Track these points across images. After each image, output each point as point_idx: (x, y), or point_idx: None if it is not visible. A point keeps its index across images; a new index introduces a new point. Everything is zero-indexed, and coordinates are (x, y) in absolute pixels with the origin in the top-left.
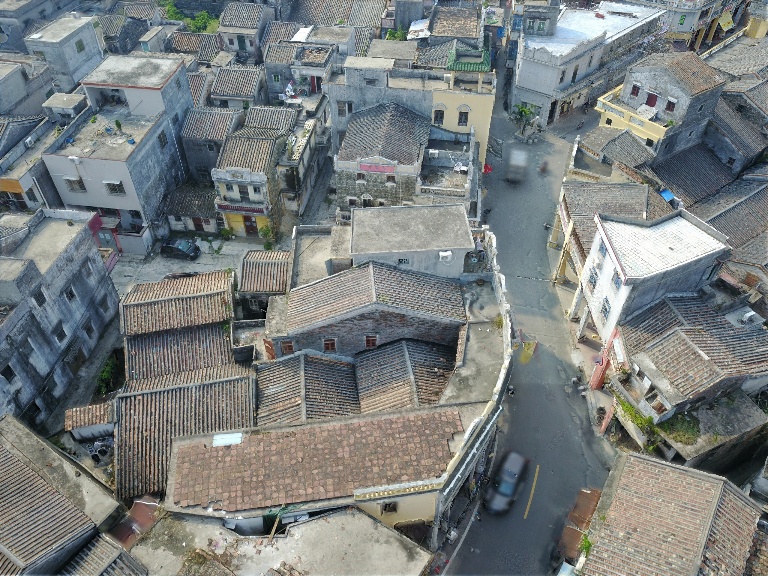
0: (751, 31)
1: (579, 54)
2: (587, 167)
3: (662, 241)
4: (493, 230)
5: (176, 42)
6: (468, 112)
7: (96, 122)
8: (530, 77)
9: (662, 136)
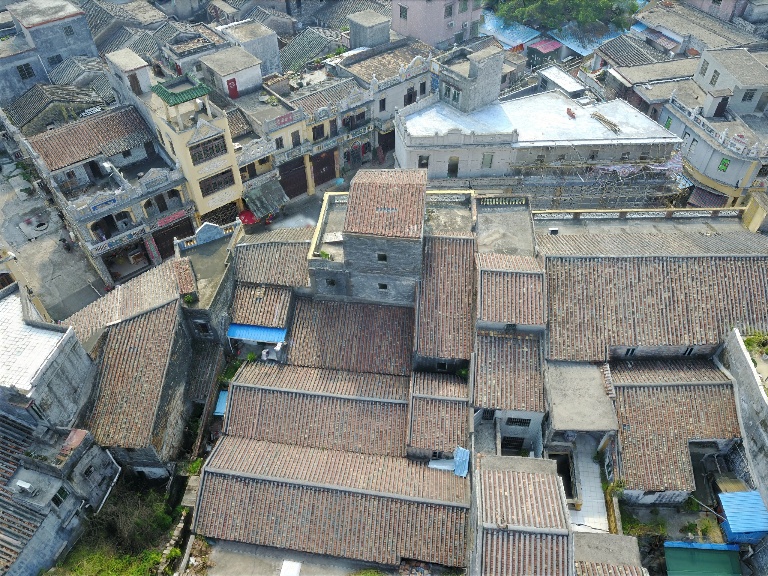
0: (747, 215)
1: (454, 144)
2: (209, 253)
3: (4, 343)
4: None
5: (211, 4)
6: (172, 143)
7: (4, 41)
8: (399, 149)
9: (308, 265)
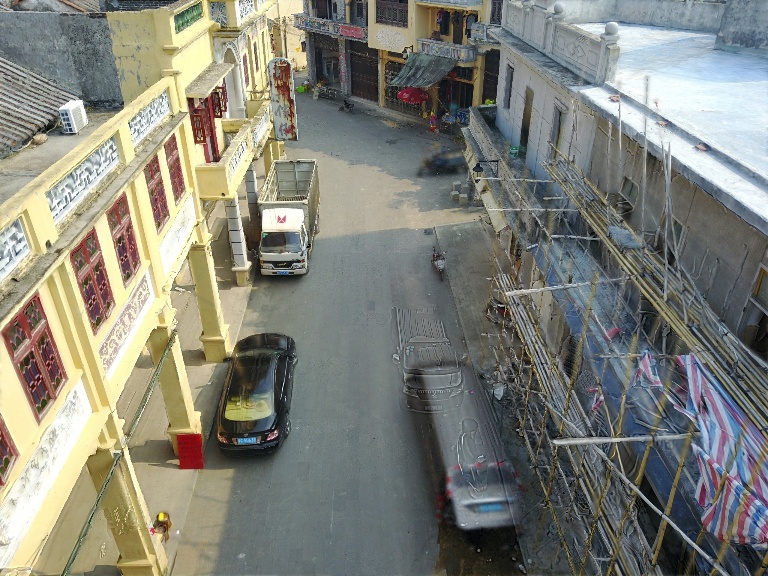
0: None
1: (537, 45)
2: None
3: None
4: (324, 109)
5: None
6: None
7: None
8: None
9: None
